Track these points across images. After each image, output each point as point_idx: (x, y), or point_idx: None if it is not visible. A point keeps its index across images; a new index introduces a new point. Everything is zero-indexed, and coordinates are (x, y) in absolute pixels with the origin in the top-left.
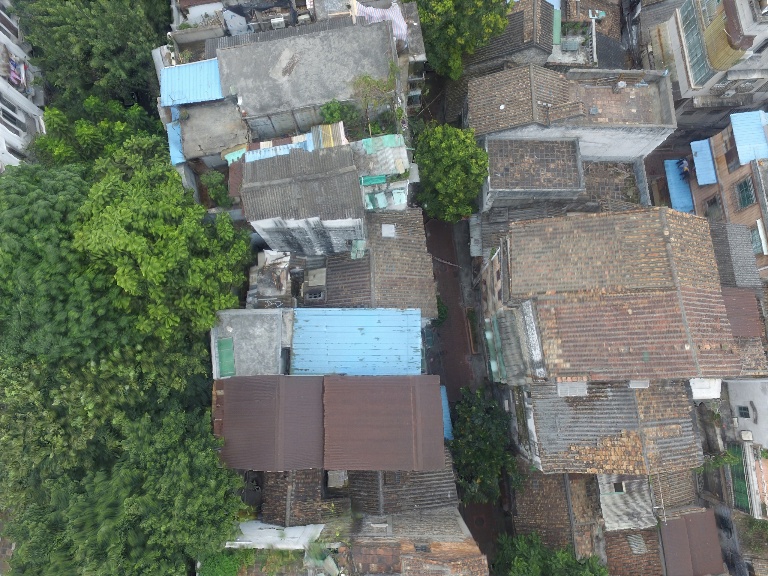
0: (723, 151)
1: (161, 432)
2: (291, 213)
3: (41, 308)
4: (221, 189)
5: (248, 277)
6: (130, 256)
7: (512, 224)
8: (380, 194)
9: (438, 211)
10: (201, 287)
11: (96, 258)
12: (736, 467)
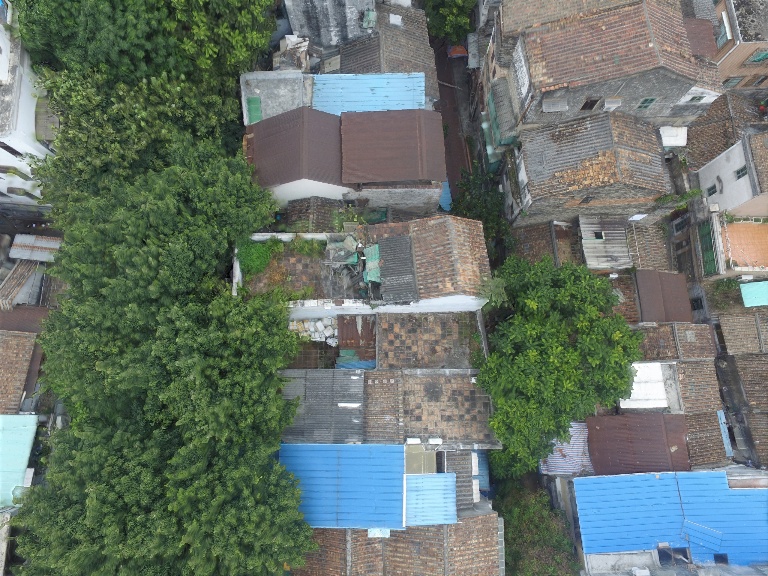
0: None
1: None
2: None
3: (106, 9)
4: None
5: (271, 61)
6: None
7: None
8: None
9: (439, 30)
10: (237, 17)
11: None
12: (705, 239)
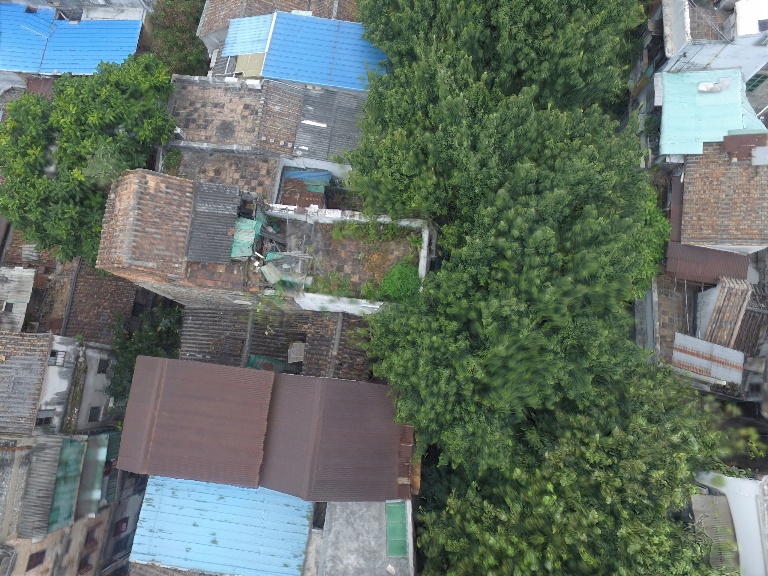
0: None
1: None
2: None
3: None
4: None
5: None
6: None
7: None
8: None
9: None
10: None
11: None
12: None
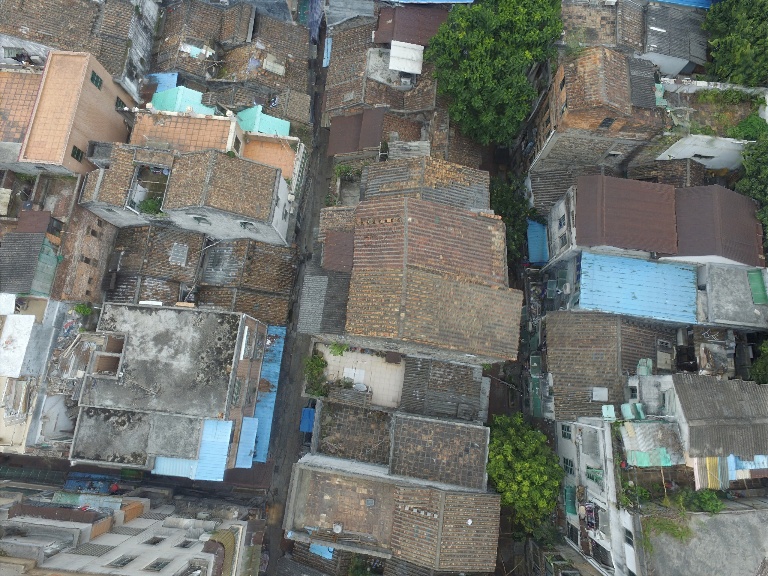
0: None
1: None
2: (747, 387)
3: None
4: None
5: None
6: None
7: None
8: (629, 418)
9: None
10: None
11: None
12: (301, 180)
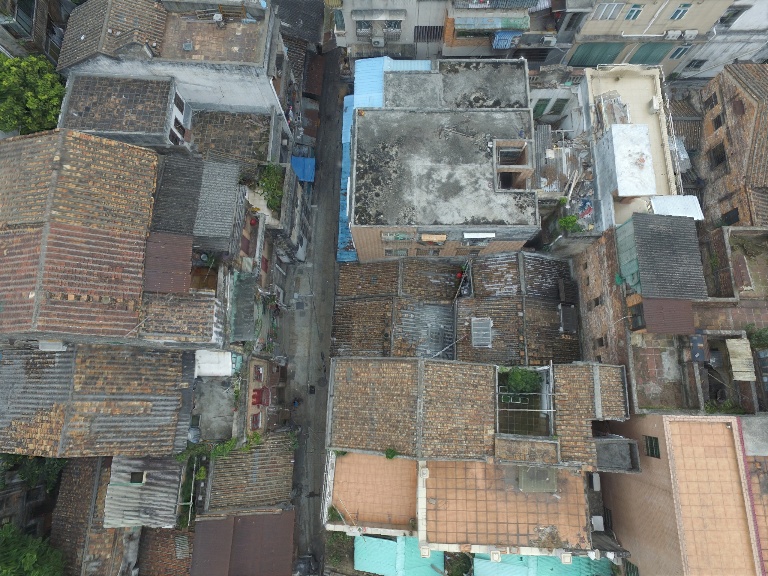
0: None
1: None
2: None
3: None
4: None
5: None
6: None
7: None
8: None
9: None
10: None
11: None
12: None
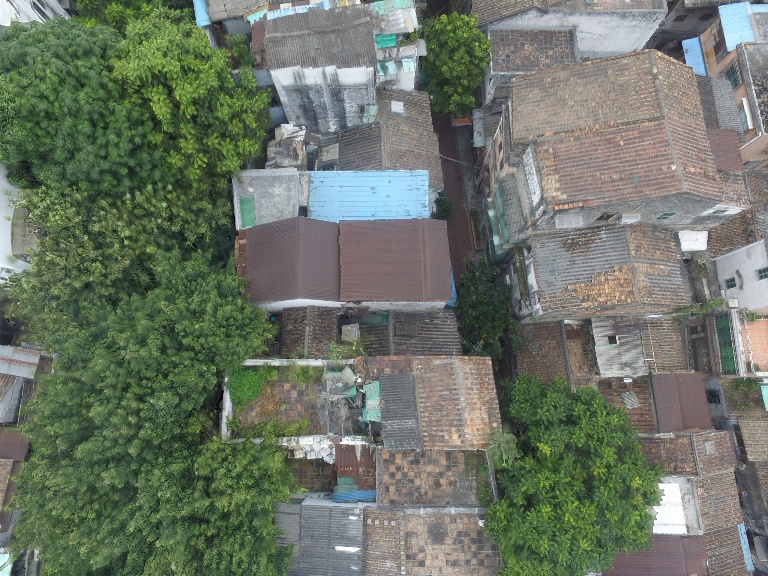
0: (712, 44)
1: (191, 261)
2: (310, 62)
3: (85, 129)
4: (244, 49)
5: (266, 150)
6: (165, 83)
7: (513, 79)
8: (390, 62)
9: (443, 106)
10: (227, 127)
11: (133, 91)
12: (723, 335)
